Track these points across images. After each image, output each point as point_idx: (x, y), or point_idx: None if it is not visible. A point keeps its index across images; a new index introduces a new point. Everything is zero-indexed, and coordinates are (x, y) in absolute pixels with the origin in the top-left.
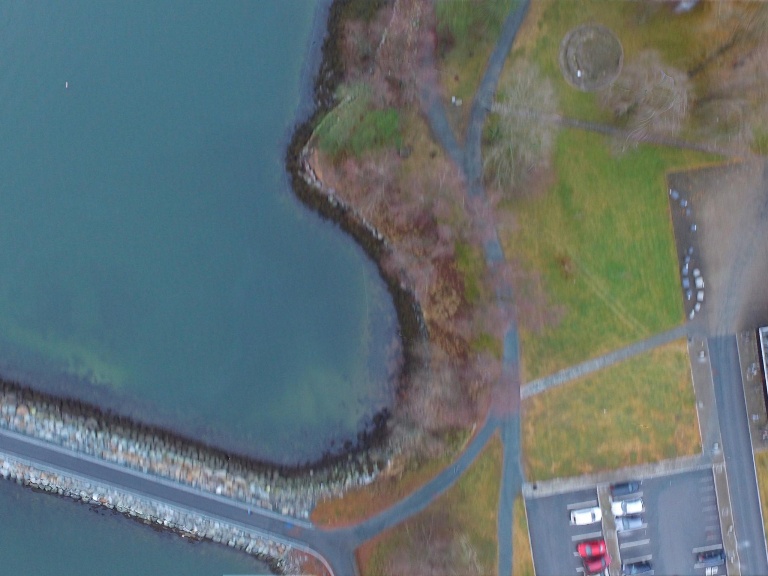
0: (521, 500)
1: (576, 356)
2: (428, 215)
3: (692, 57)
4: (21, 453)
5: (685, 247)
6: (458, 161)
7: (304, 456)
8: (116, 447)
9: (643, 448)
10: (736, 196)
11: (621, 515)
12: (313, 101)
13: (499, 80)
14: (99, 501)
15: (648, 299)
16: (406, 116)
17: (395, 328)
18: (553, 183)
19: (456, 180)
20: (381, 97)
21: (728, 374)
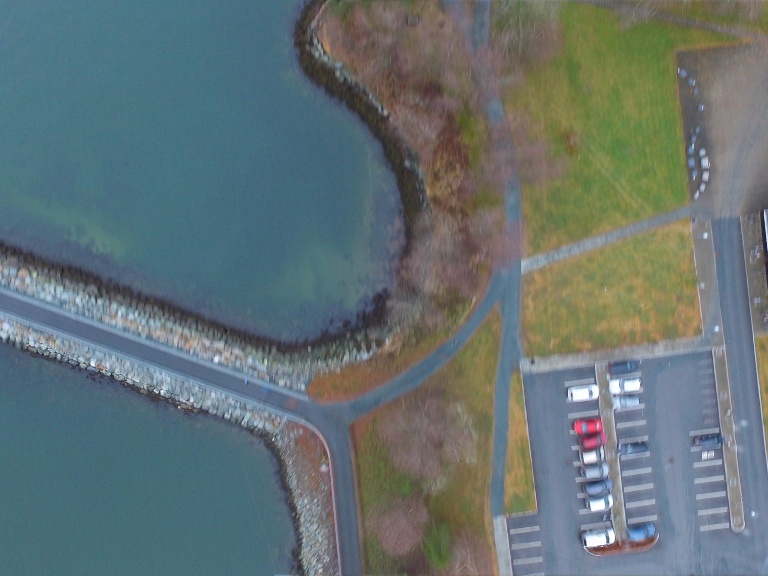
0: (518, 375)
1: (578, 232)
2: (434, 87)
3: None
4: (21, 314)
5: (692, 127)
6: (466, 32)
7: (302, 333)
8: (115, 313)
9: (643, 328)
10: (745, 77)
11: (618, 393)
12: None
13: None
14: (97, 367)
15: (653, 178)
16: None
17: (398, 208)
18: (561, 58)
19: (464, 51)
20: None
21: (731, 256)
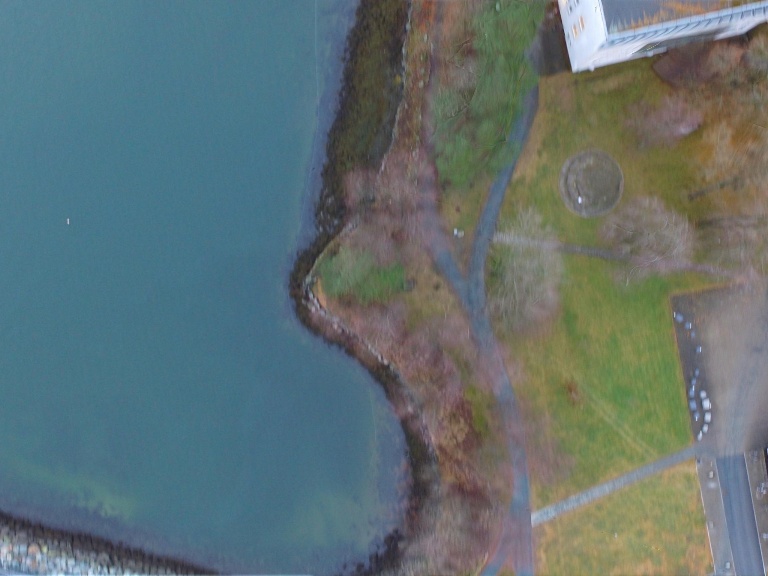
0: None
1: (586, 482)
2: (433, 345)
3: (692, 181)
4: None
5: (691, 369)
6: (462, 292)
7: None
8: None
9: (655, 570)
10: (740, 317)
11: None
12: (314, 227)
13: (500, 210)
14: None
15: (656, 422)
16: (409, 249)
17: (403, 449)
18: (557, 310)
19: (460, 311)
20: (383, 228)
21: (737, 493)
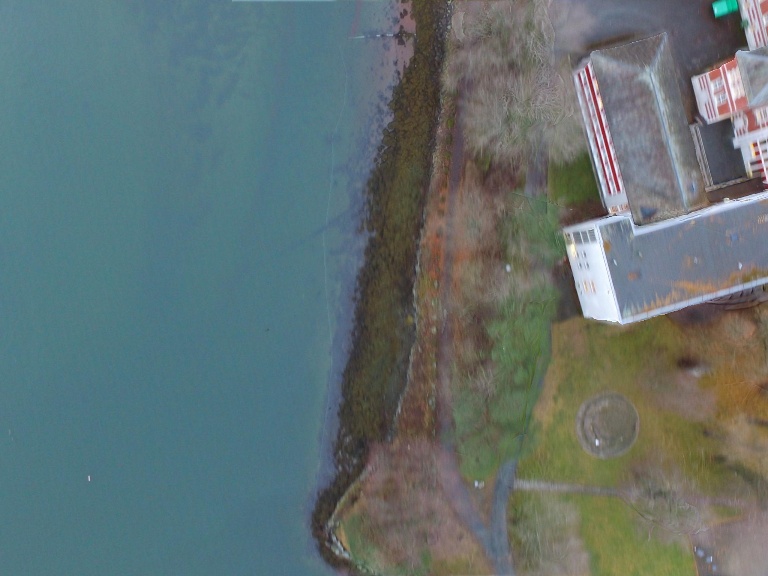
0: None
1: None
2: None
3: (707, 419)
4: None
5: None
6: (485, 541)
7: None
8: None
9: None
10: (759, 547)
11: None
12: (334, 466)
13: (519, 457)
14: None
15: None
16: (430, 502)
17: None
18: (580, 553)
19: (485, 559)
20: (403, 477)
21: None
